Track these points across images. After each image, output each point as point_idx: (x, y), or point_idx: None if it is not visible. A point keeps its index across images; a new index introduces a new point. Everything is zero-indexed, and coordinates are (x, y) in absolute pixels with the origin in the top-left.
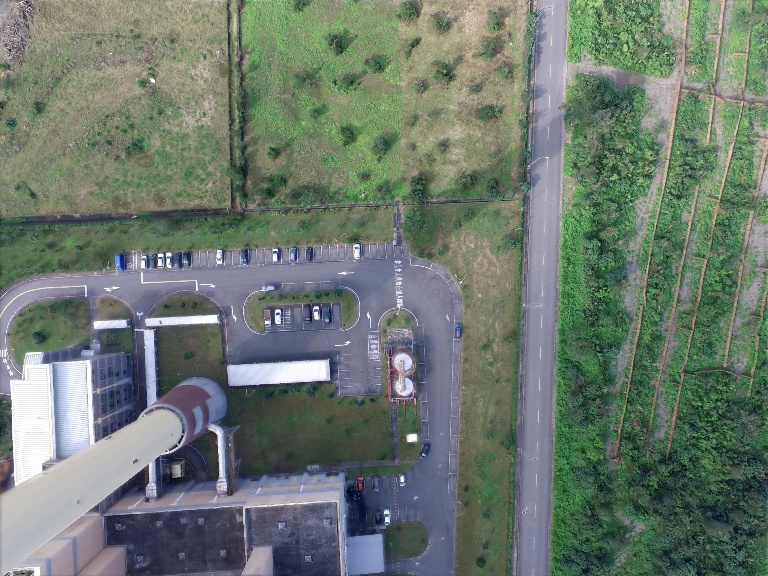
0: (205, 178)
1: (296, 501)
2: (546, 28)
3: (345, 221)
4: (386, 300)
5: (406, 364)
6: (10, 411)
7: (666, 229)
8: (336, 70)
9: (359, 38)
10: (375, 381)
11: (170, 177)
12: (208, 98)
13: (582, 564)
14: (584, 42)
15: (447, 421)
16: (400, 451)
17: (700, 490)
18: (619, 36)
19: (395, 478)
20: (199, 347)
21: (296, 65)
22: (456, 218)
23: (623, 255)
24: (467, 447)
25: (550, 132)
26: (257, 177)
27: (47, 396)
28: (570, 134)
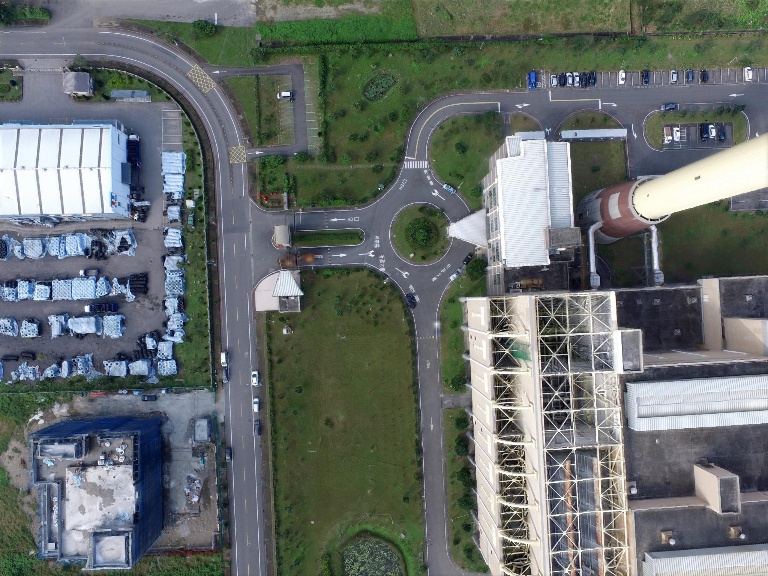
0: (608, 3)
1: None
2: None
3: None
4: None
5: None
6: (432, 218)
7: None
8: None
9: None
10: (764, 197)
11: (577, 1)
12: None
13: None
14: None
15: None
16: None
17: None
18: None
19: None
20: (604, 162)
21: None
22: None
23: None
24: None
25: None
26: (654, 3)
27: (544, 169)
28: None
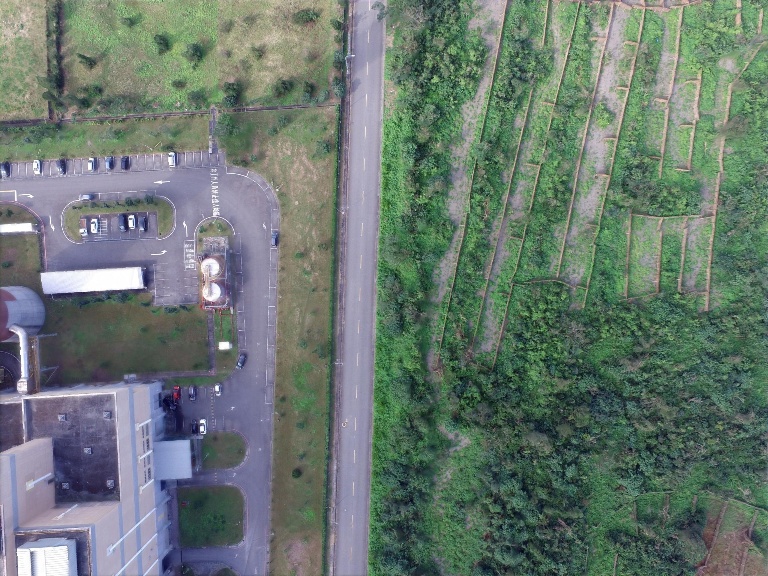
0: (22, 89)
1: (75, 393)
2: None
3: None
4: (202, 209)
5: (213, 269)
6: None
7: (493, 133)
8: None
9: None
10: (191, 290)
11: None
12: (26, 10)
13: (399, 476)
14: None
15: (264, 331)
16: (217, 361)
17: (527, 403)
18: None
19: (212, 388)
20: (18, 256)
21: None
22: (272, 125)
23: (448, 161)
24: (284, 357)
25: (370, 35)
26: (74, 87)
27: None
28: (392, 37)
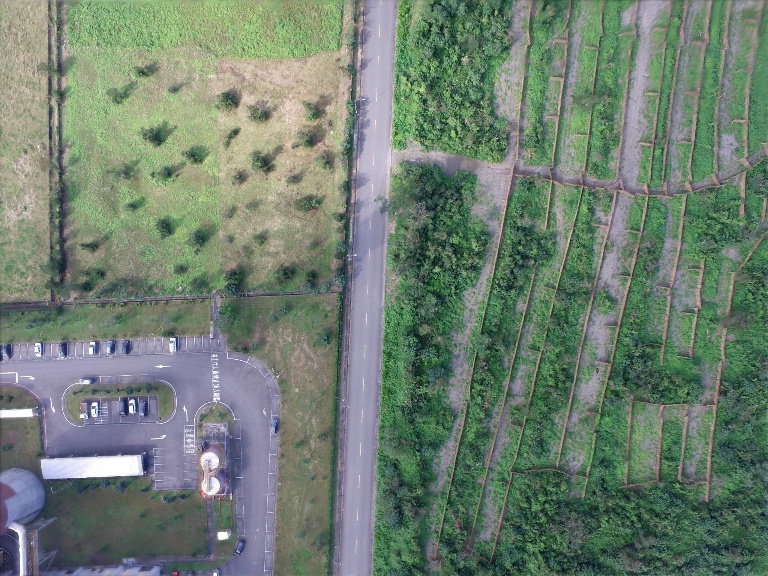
0: (25, 272)
1: None
2: (370, 115)
3: (162, 314)
4: (203, 394)
5: (212, 463)
6: None
7: (494, 322)
8: (155, 162)
9: (178, 129)
10: (191, 475)
11: None
12: (29, 192)
13: None
14: (408, 129)
15: (263, 517)
16: (215, 546)
17: None
18: (447, 121)
19: (210, 573)
20: (18, 439)
21: (115, 158)
22: (274, 311)
23: (449, 348)
24: (283, 544)
25: (373, 222)
26: (76, 270)
27: None
28: (394, 224)
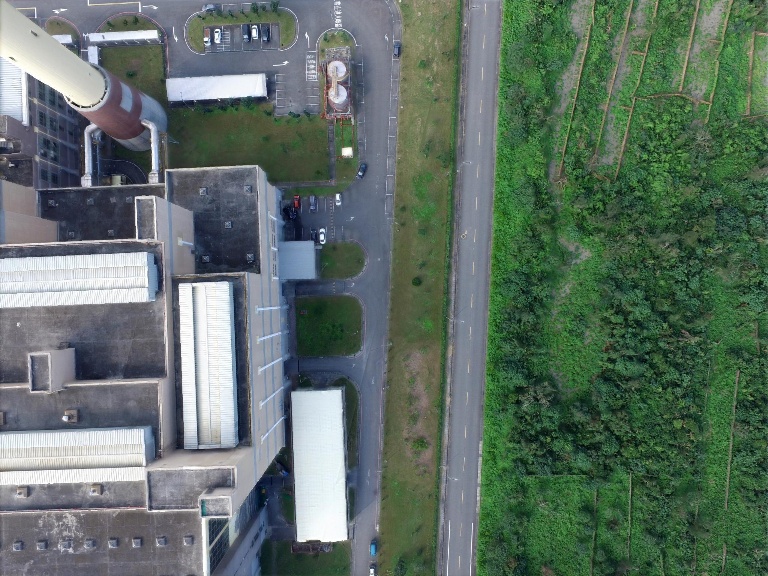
0: None
1: None
2: None
3: None
4: (324, 20)
5: (340, 71)
6: None
7: None
8: None
9: None
10: (312, 101)
11: None
12: None
13: (521, 283)
14: None
15: (385, 141)
16: (337, 171)
17: (650, 214)
18: None
19: (332, 198)
20: (141, 66)
21: None
22: None
23: None
24: (405, 167)
25: None
26: None
27: None
28: None
